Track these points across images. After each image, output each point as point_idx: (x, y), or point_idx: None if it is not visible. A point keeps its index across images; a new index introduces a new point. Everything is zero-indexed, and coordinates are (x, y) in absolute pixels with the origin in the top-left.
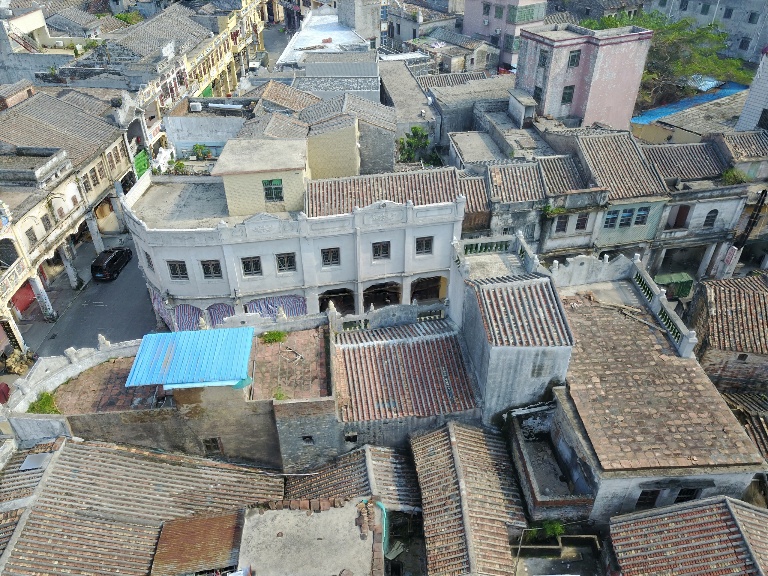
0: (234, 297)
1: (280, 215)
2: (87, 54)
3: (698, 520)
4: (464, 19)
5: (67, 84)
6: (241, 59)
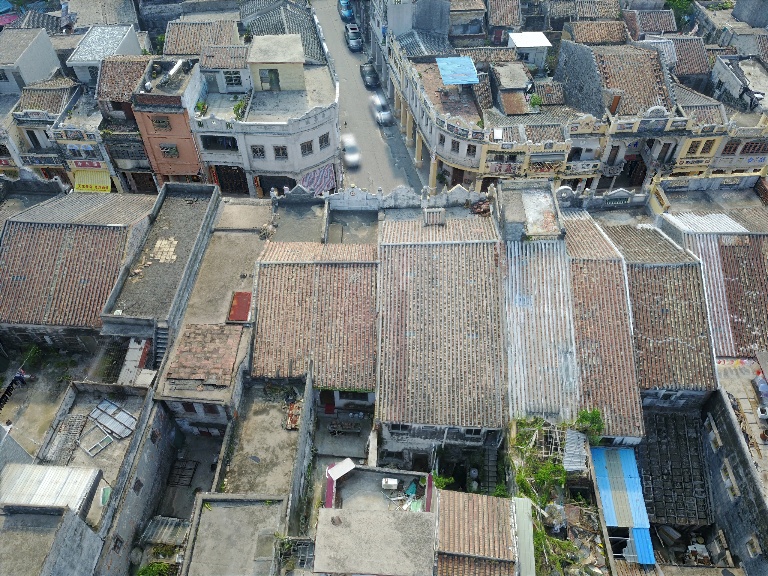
0: (345, 124)
1: (307, 73)
2: None
3: (494, 5)
4: None
5: None
6: None
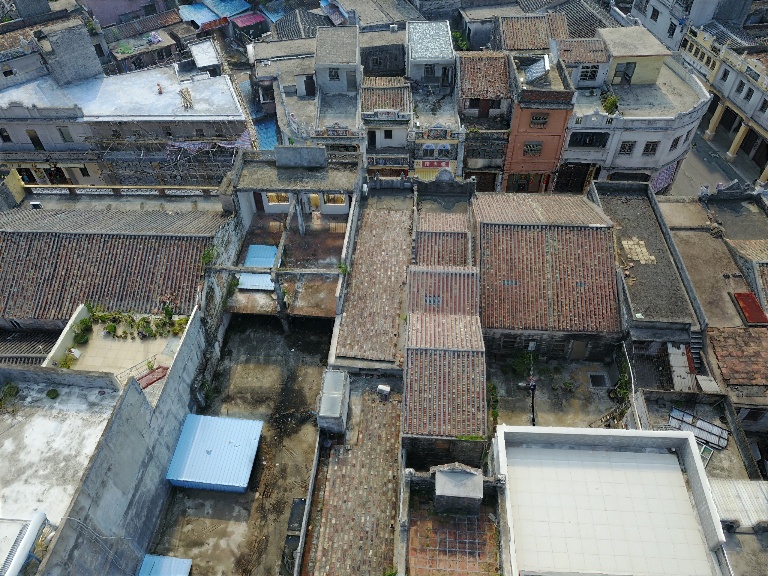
0: None
1: None
2: (237, 267)
3: None
4: (94, 9)
5: (348, 270)
6: None
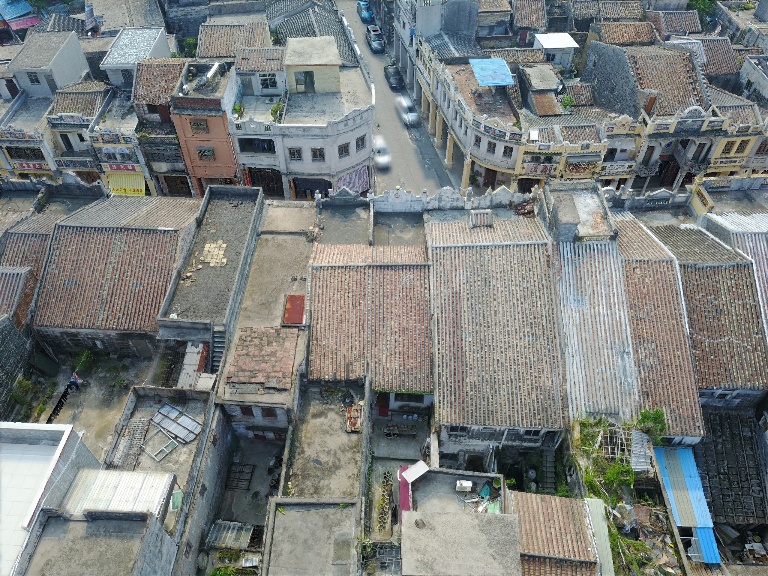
0: (377, 126)
1: (340, 75)
2: None
3: (519, 6)
4: None
5: None
6: None
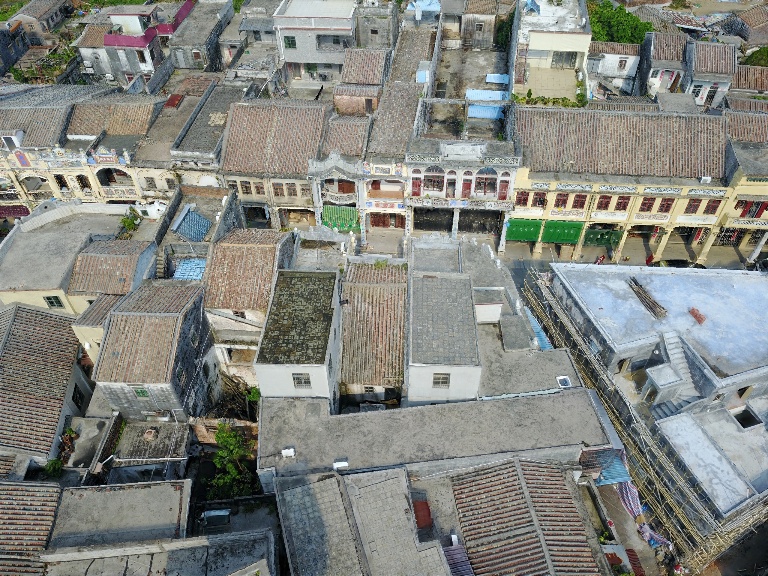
0: None
1: None
2: (493, 102)
3: None
4: None
5: None
6: (761, 240)
